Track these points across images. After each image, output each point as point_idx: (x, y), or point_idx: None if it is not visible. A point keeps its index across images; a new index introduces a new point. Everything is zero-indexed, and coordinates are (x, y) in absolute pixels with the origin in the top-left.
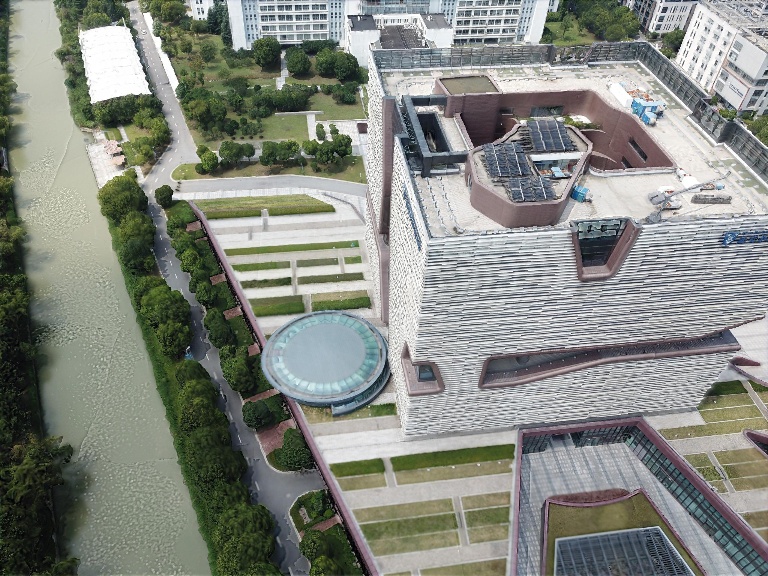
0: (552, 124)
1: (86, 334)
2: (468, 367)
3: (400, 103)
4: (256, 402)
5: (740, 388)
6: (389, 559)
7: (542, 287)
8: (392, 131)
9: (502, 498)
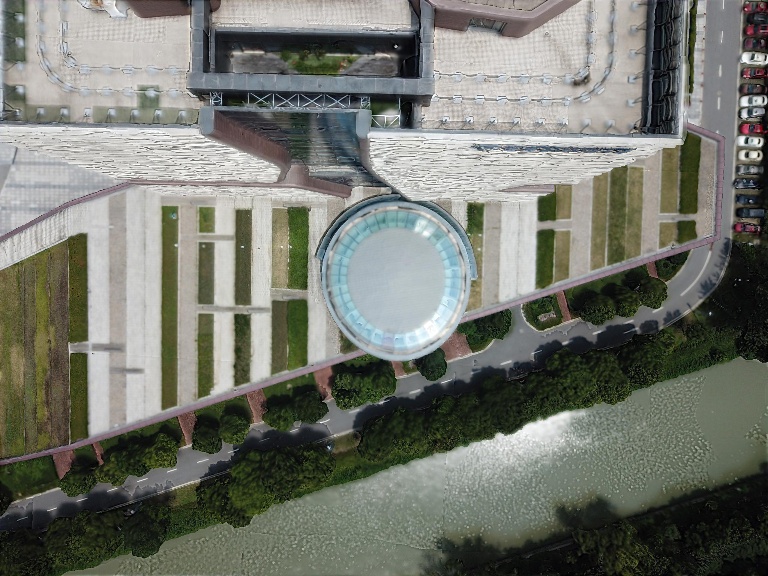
0: None
1: (254, 572)
2: None
3: (152, 94)
4: (433, 366)
5: None
6: (645, 241)
7: None
8: (245, 130)
9: None
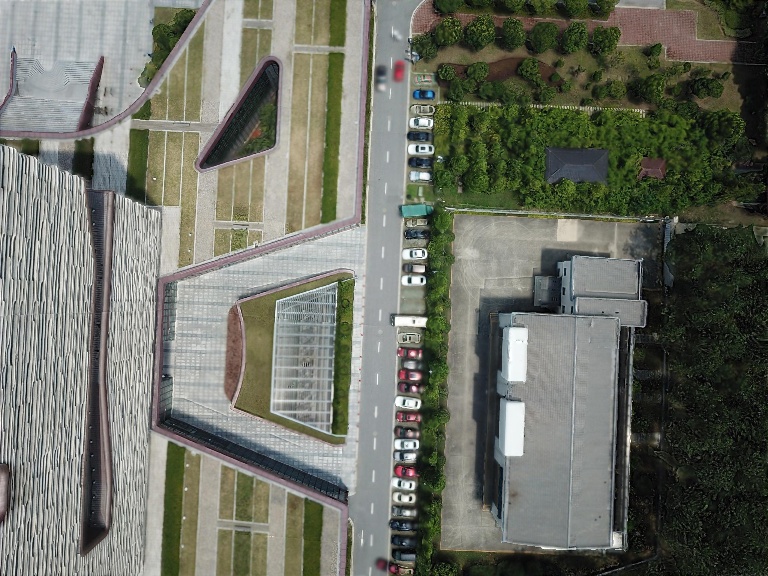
0: None
1: None
2: (86, 573)
3: None
4: None
5: (142, 137)
6: None
7: (6, 568)
8: None
9: (227, 476)
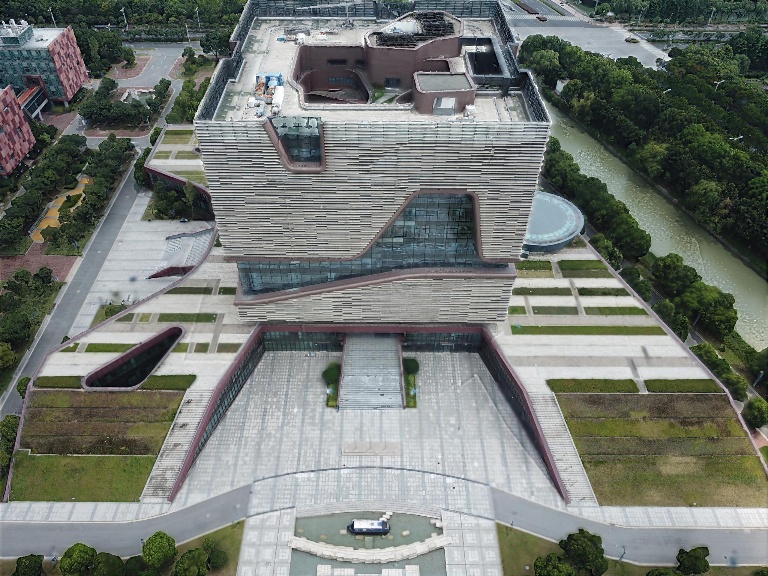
0: (393, 34)
1: None
2: None
3: None
4: None
5: None
6: None
7: None
8: None
9: None
